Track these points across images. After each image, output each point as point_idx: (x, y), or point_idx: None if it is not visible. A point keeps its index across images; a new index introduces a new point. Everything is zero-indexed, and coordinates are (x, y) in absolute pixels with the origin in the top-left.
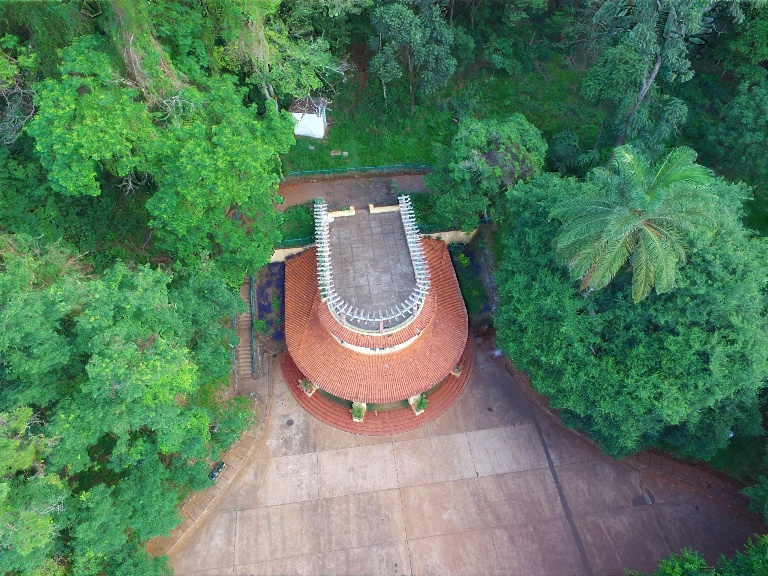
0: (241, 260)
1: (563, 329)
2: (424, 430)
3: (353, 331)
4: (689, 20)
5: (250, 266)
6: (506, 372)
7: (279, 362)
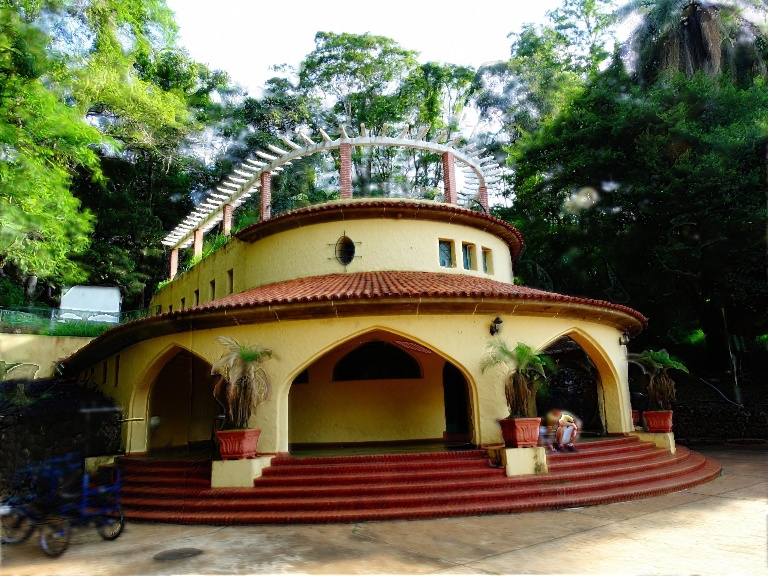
0: (4, 126)
1: (757, 78)
2: (740, 475)
3: (382, 199)
4: (552, 107)
5: (3, 202)
6: (705, 446)
7: (33, 506)
